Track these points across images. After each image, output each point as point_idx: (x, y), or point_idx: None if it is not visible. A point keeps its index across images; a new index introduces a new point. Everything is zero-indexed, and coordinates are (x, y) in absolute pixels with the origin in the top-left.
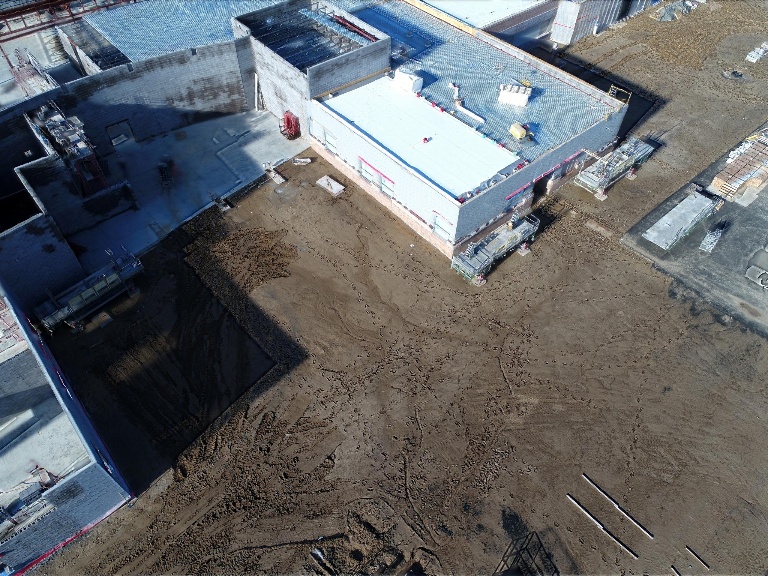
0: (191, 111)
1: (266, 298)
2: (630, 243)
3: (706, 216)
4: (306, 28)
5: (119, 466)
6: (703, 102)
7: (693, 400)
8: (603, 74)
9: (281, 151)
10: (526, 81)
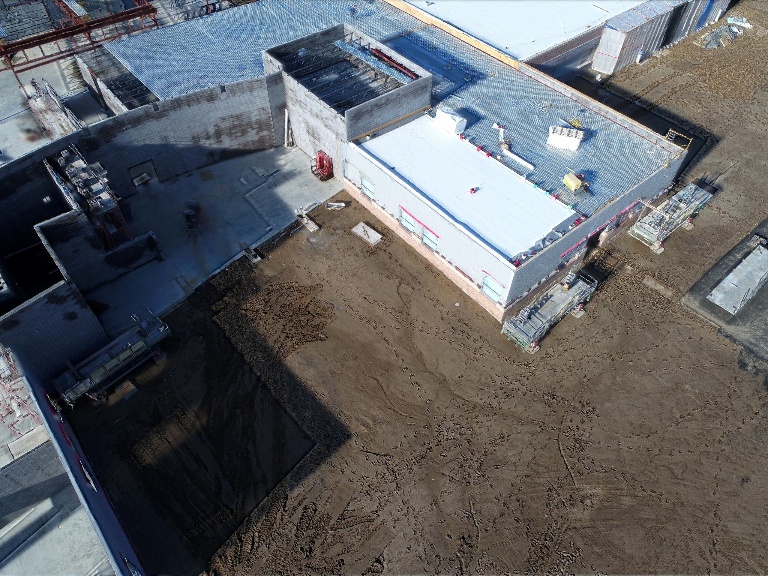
0: (217, 149)
1: (302, 365)
2: (693, 304)
3: None
4: (338, 59)
5: (147, 569)
6: (758, 140)
7: None
8: (649, 108)
9: (313, 194)
10: (575, 121)
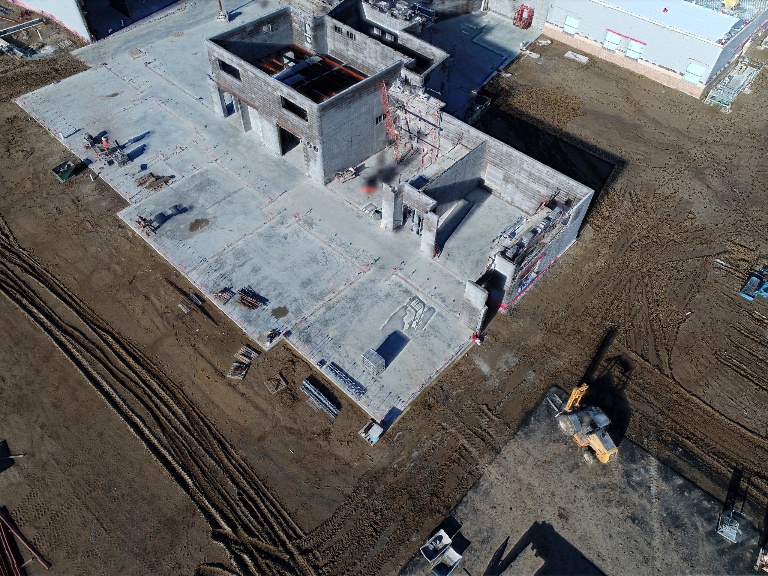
0: (440, 10)
1: (579, 128)
2: None
3: None
4: None
5: None
6: None
7: None
8: None
9: (522, 37)
10: None
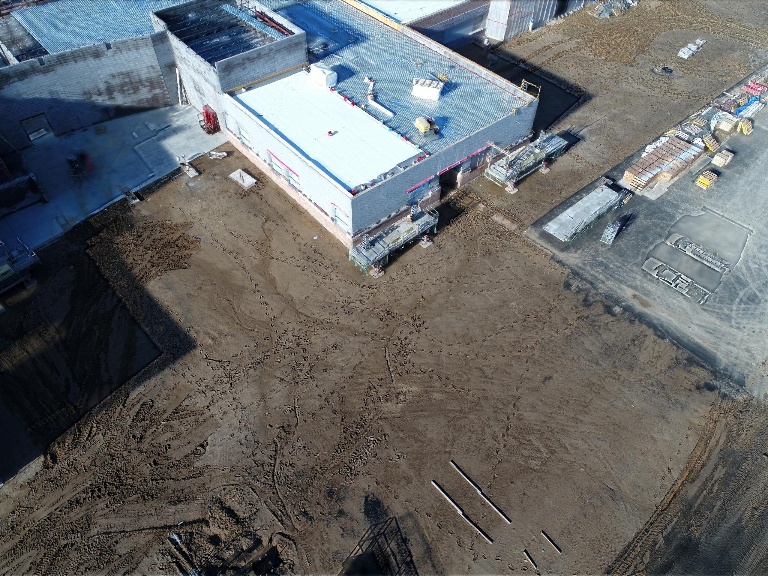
0: (111, 105)
1: (162, 289)
2: (533, 235)
3: (612, 209)
4: (233, 23)
5: None
6: (629, 97)
7: (572, 389)
8: (533, 70)
9: (199, 145)
10: (443, 76)
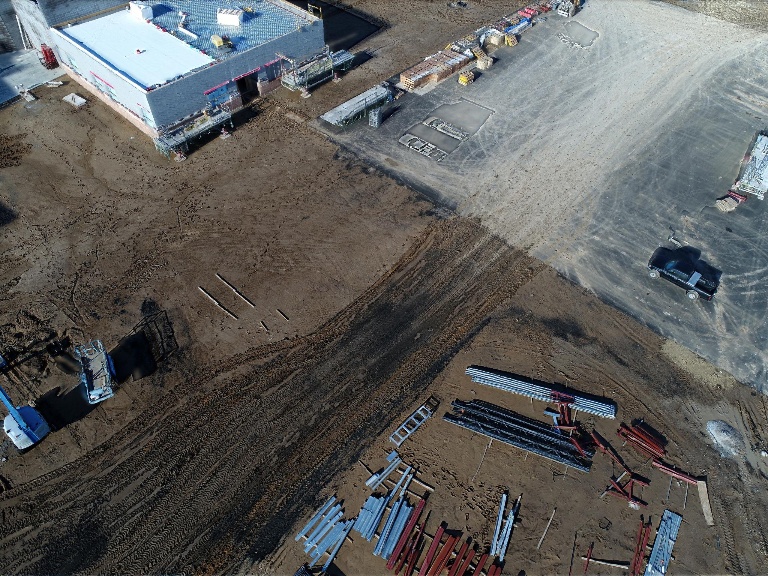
0: None
1: None
2: (315, 125)
3: (385, 103)
4: None
5: None
6: (423, 25)
7: (322, 223)
8: (346, 8)
9: (38, 78)
10: (248, 8)
